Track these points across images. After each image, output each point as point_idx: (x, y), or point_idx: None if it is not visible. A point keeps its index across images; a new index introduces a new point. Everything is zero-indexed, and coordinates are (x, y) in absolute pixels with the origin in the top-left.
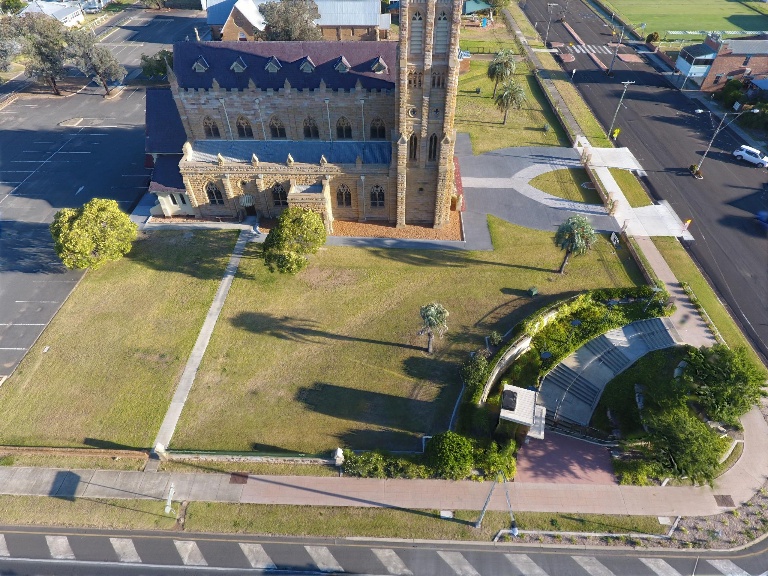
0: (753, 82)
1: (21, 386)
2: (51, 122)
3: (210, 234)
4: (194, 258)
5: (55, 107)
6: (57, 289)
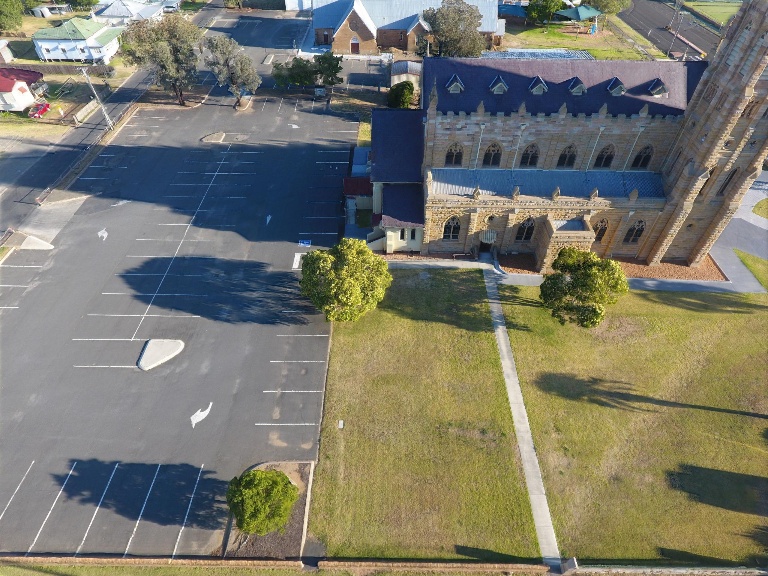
0: None
1: (338, 475)
2: (191, 137)
3: (449, 274)
4: (447, 304)
5: (186, 120)
6: (311, 345)
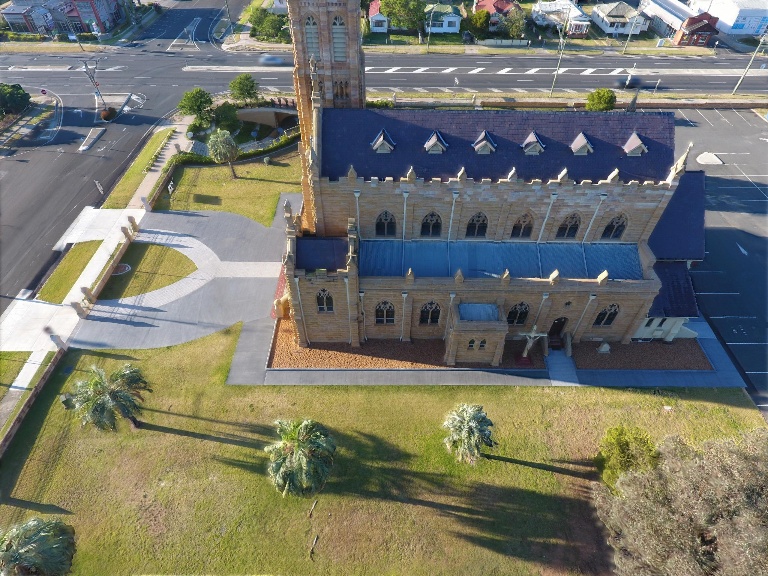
0: None
1: None
2: None
3: None
4: None
5: None
6: None
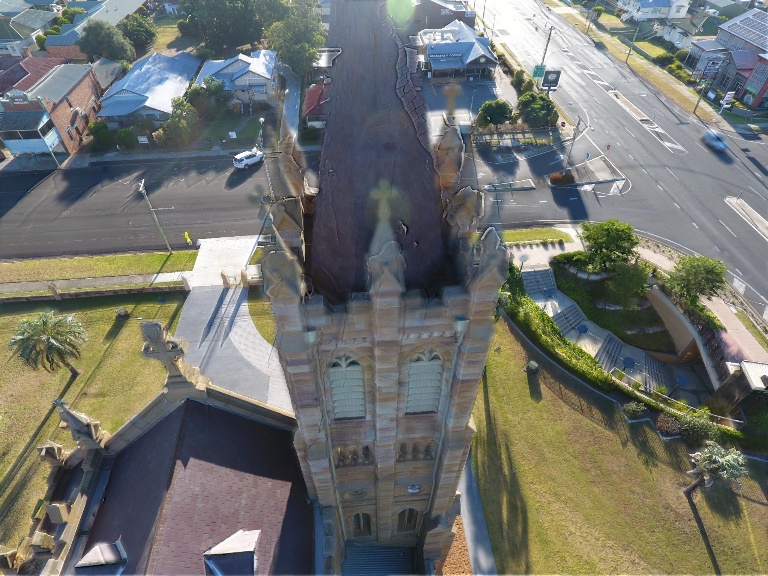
0: (104, 115)
1: None
2: None
3: None
4: None
5: None
6: None
